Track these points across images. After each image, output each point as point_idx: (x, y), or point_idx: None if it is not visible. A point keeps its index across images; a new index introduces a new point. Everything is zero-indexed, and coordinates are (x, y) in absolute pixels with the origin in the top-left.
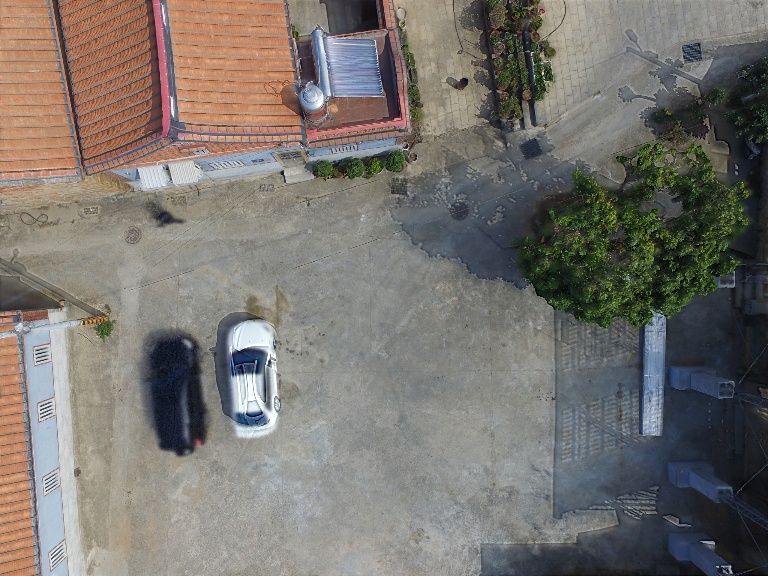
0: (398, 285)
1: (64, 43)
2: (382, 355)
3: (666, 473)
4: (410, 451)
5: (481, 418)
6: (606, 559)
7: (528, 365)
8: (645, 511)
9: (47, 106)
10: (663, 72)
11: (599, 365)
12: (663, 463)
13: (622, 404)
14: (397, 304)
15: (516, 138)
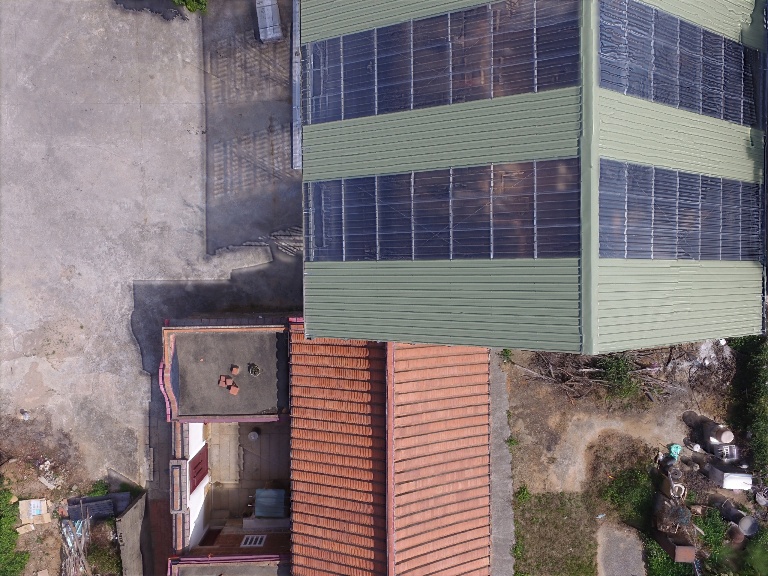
0: (43, 15)
1: None
2: (29, 87)
3: (319, 209)
4: (59, 185)
5: (131, 152)
6: (260, 296)
7: (177, 98)
8: (299, 247)
9: None
10: None
11: (250, 98)
12: (316, 198)
13: (274, 138)
14: (43, 35)
15: None
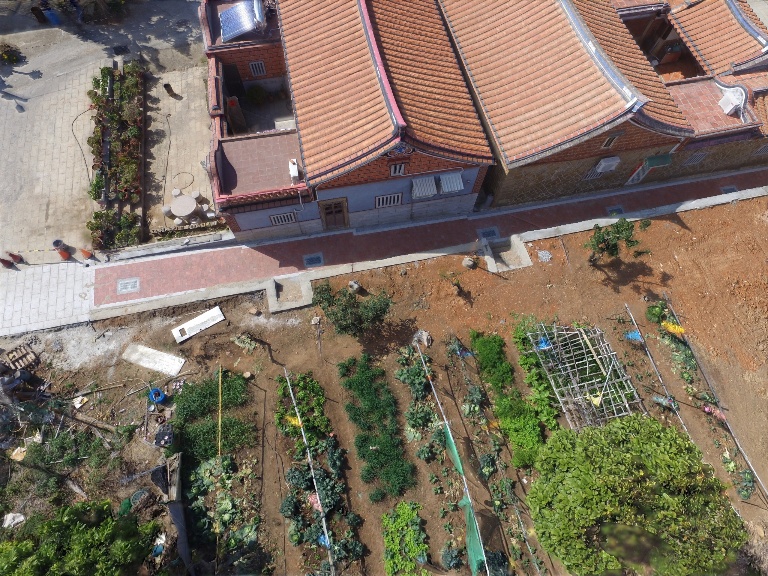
0: None
1: (443, 23)
2: None
3: None
4: None
5: None
6: None
7: None
8: None
9: (455, 2)
10: (1, 87)
11: None
12: None
13: None
14: None
15: (132, 57)
